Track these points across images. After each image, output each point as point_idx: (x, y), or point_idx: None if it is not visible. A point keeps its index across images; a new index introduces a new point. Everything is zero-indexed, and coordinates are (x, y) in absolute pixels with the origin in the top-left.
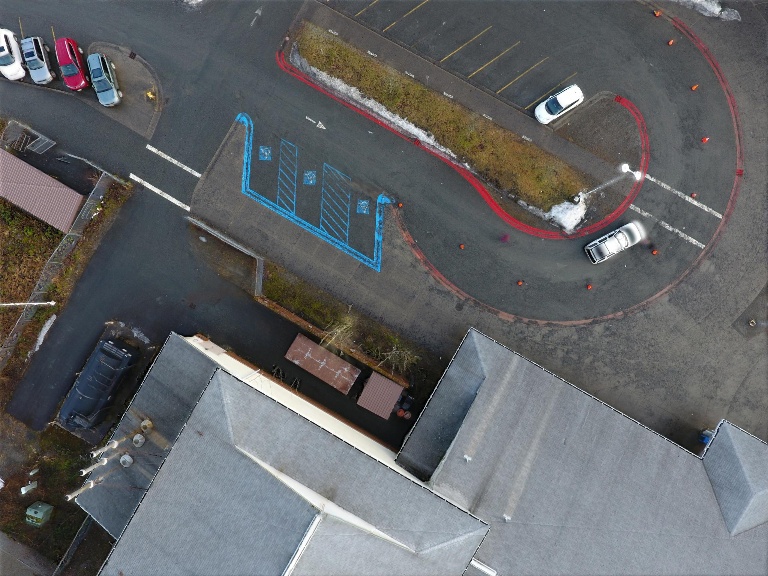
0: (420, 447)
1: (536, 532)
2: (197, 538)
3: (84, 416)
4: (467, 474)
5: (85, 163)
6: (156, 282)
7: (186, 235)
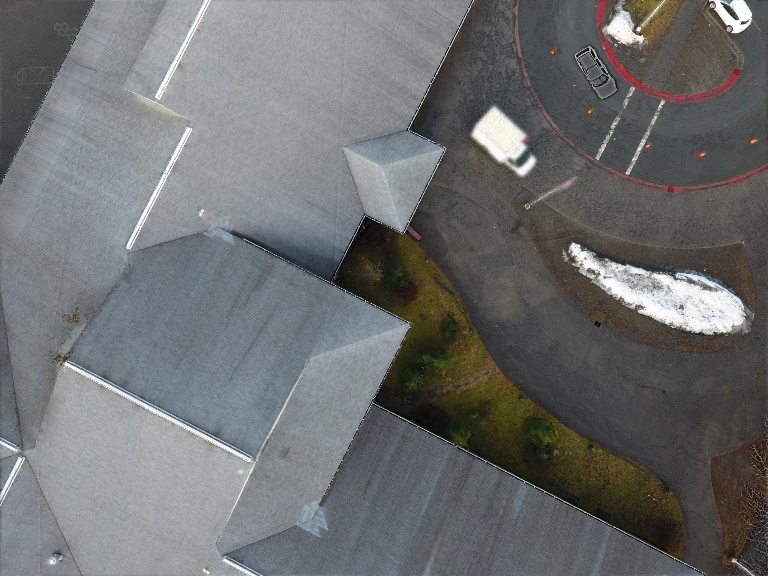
0: None
1: None
2: None
3: None
4: None
5: None
6: None
7: None
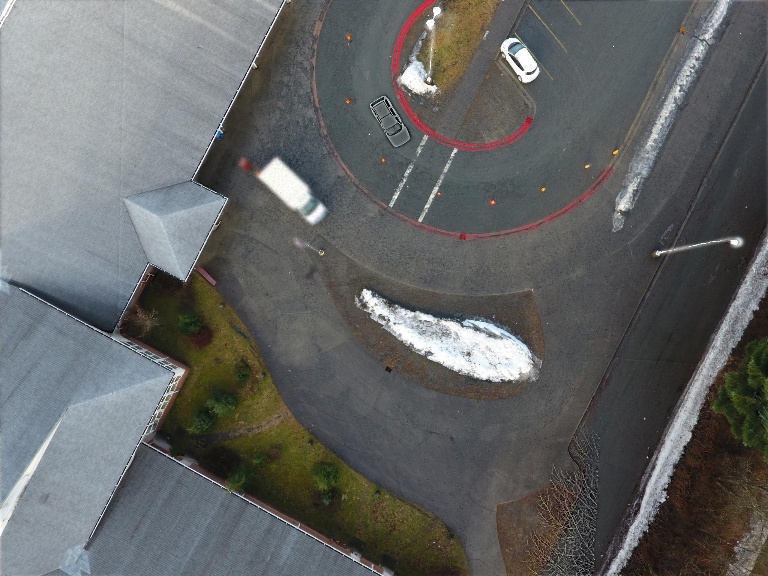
0: None
1: (118, 8)
2: None
3: None
4: None
5: None
6: None
7: None
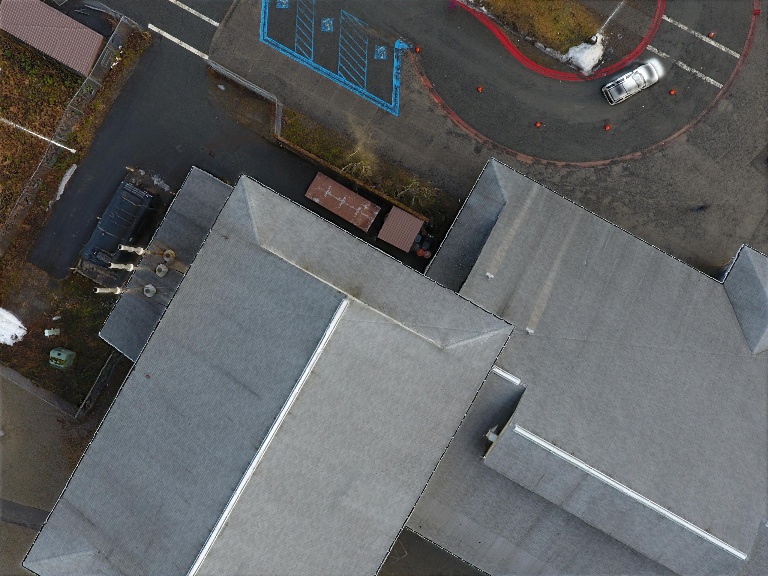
0: (441, 275)
1: (559, 345)
2: (224, 335)
3: (107, 252)
4: (489, 290)
5: (104, 14)
6: (175, 130)
7: (205, 83)
